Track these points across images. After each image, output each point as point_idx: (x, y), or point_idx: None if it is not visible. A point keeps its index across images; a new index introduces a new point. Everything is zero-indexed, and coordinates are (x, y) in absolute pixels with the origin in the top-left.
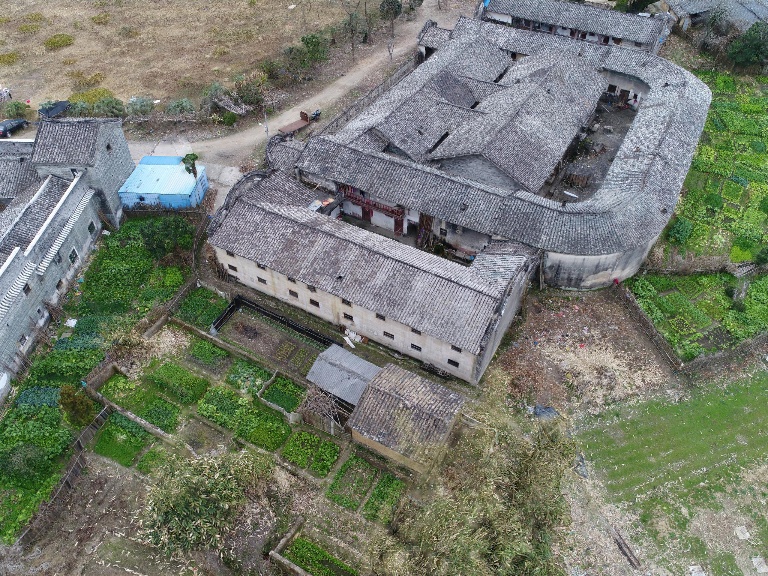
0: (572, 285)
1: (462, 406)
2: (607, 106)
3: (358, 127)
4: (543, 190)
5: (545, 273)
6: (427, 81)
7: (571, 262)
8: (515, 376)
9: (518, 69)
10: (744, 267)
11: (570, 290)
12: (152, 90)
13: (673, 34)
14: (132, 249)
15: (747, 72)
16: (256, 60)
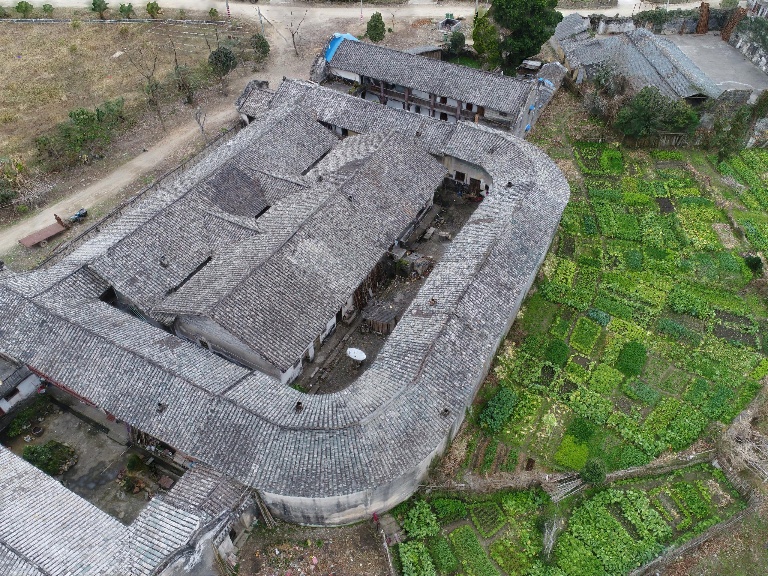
0: (313, 522)
1: None
2: (457, 196)
3: (78, 258)
4: (336, 335)
5: (271, 509)
6: (196, 183)
7: (298, 502)
8: None
9: (334, 156)
10: (567, 483)
11: (314, 526)
12: None
13: (564, 89)
14: None
15: (640, 144)
16: (46, 129)
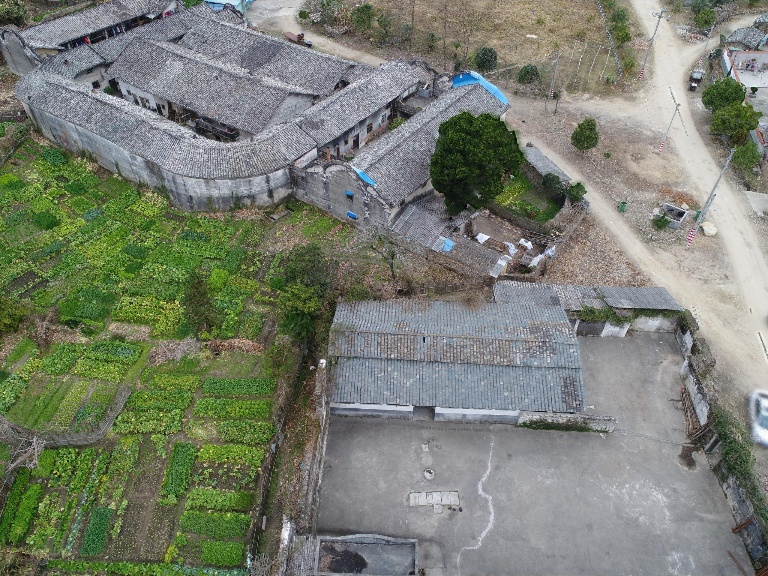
0: None
1: (5, 69)
2: None
3: None
4: None
5: None
6: None
7: None
8: (6, 82)
9: None
10: None
11: None
12: (374, 3)
13: None
14: (187, 5)
15: None
16: (421, 30)
